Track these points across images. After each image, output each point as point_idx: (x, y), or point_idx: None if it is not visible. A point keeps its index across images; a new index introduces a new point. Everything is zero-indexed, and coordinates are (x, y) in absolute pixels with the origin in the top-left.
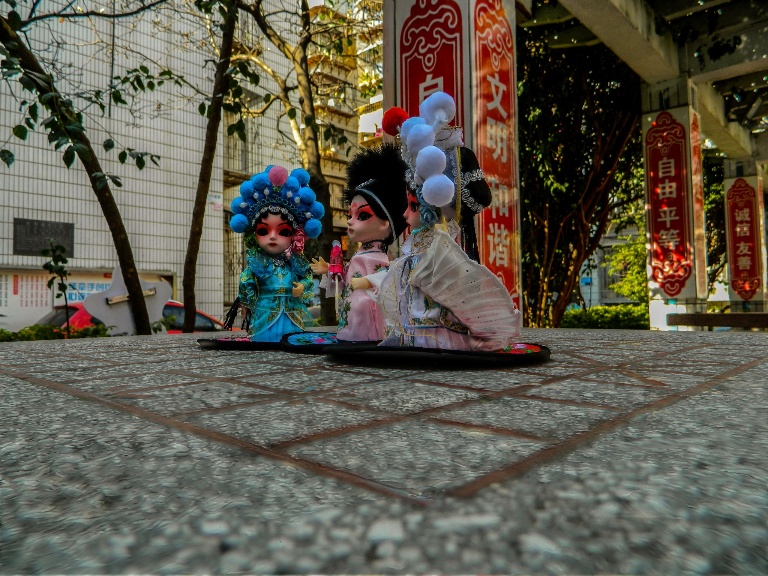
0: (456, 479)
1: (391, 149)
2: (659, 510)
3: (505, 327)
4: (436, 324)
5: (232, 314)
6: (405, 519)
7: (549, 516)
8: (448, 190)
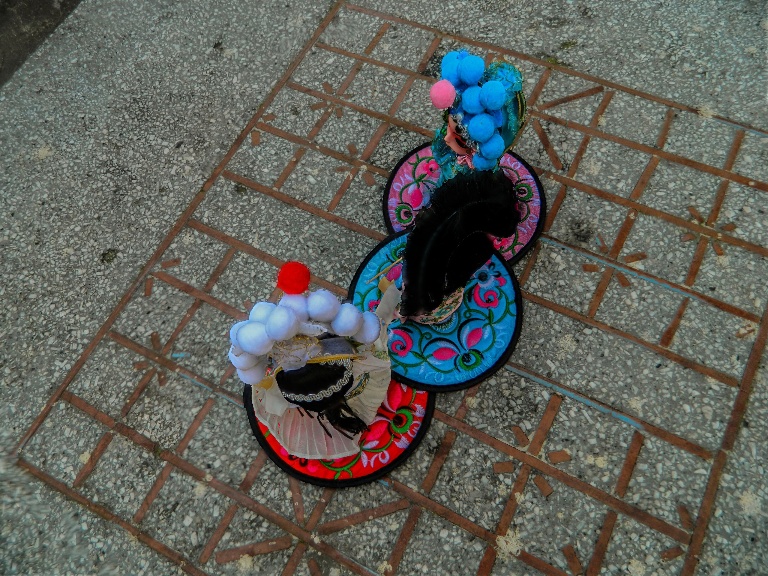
0: (34, 458)
1: None
2: (7, 512)
3: None
4: None
5: None
6: (3, 451)
7: (4, 485)
8: None
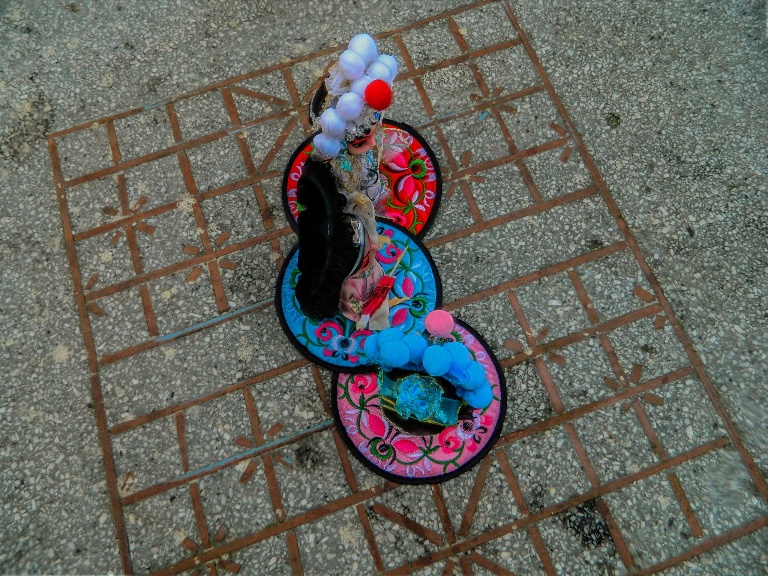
0: (489, 6)
1: None
2: None
3: None
4: None
5: None
6: None
7: None
8: None
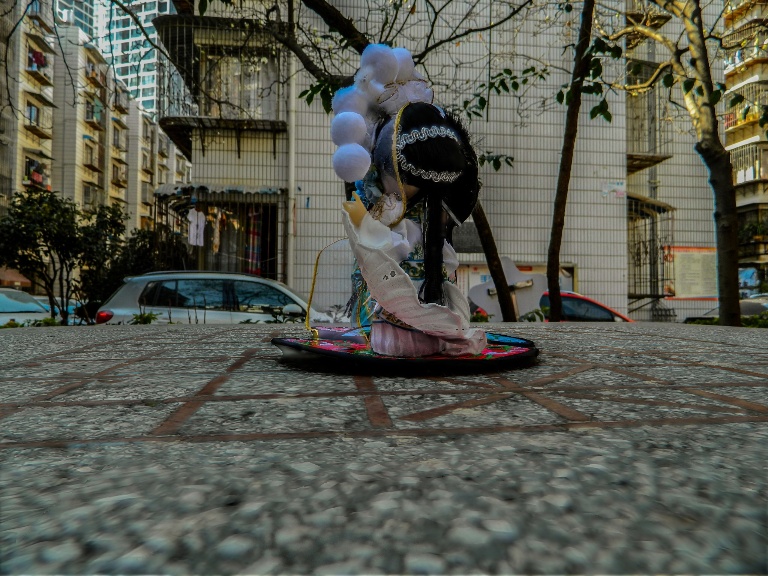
0: None
1: None
2: None
3: (443, 325)
4: (381, 318)
5: (350, 304)
6: None
7: None
8: (350, 161)
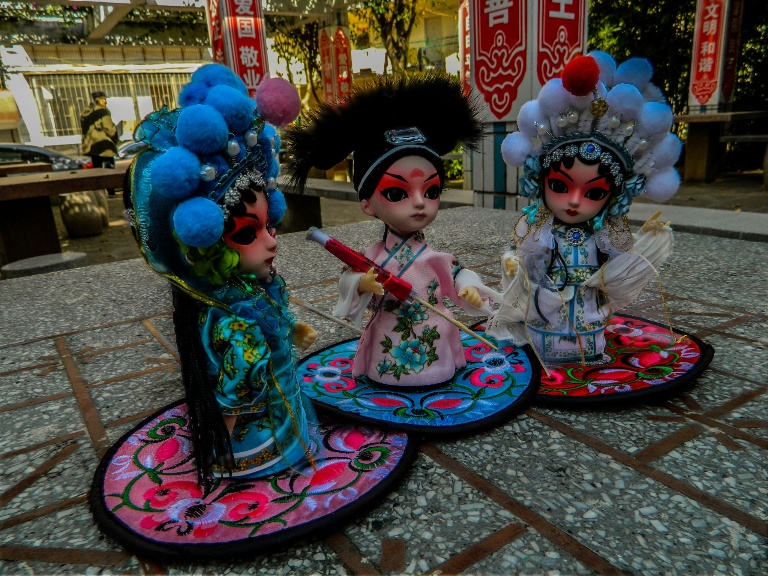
0: None
1: (449, 85)
2: None
3: None
4: None
5: (227, 445)
6: None
7: None
8: None
